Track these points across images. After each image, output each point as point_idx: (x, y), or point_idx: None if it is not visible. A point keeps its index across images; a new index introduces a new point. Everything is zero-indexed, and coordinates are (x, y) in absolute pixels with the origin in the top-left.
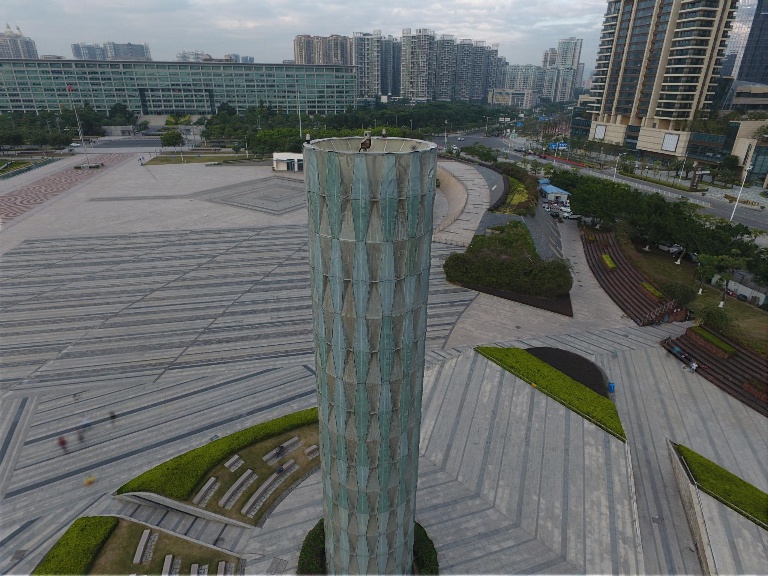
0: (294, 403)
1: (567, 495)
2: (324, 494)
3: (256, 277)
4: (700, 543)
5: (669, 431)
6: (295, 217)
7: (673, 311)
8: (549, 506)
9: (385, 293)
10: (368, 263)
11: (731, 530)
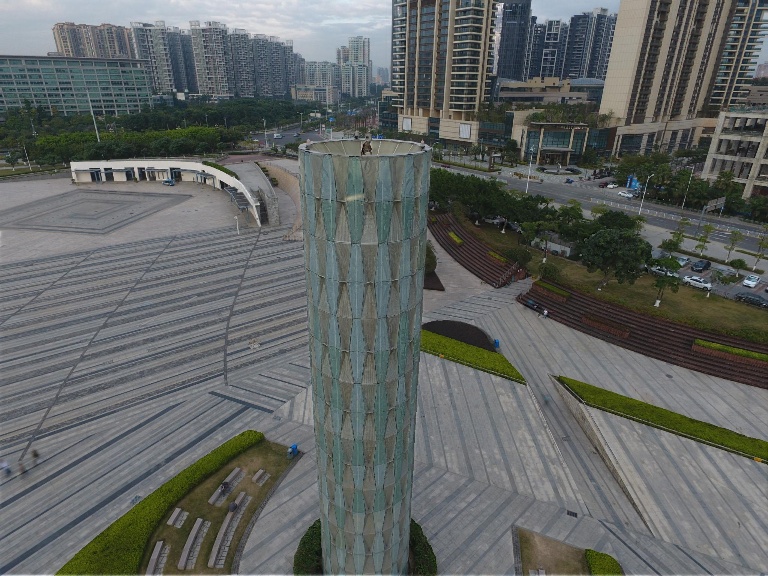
0: (217, 434)
1: (500, 441)
2: (329, 507)
3: (107, 309)
4: (600, 445)
5: (547, 368)
6: (127, 234)
7: (517, 271)
8: (490, 454)
9: (401, 290)
10: (390, 263)
11: (615, 429)
